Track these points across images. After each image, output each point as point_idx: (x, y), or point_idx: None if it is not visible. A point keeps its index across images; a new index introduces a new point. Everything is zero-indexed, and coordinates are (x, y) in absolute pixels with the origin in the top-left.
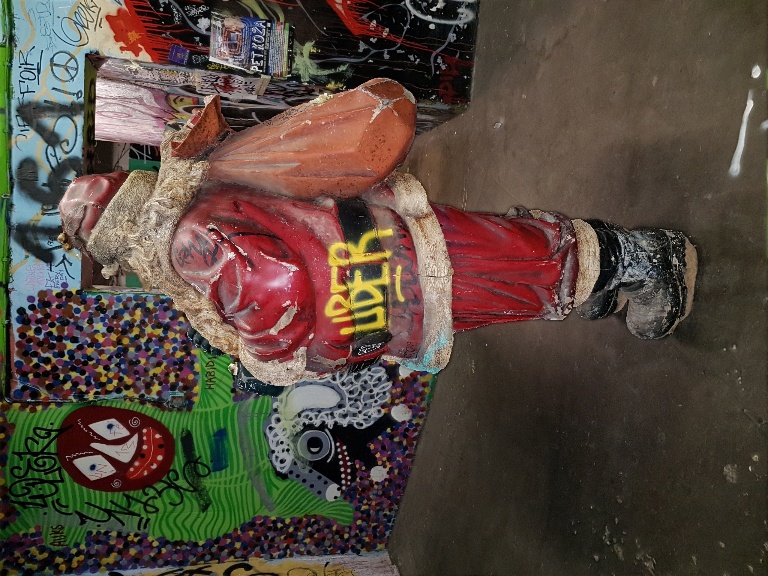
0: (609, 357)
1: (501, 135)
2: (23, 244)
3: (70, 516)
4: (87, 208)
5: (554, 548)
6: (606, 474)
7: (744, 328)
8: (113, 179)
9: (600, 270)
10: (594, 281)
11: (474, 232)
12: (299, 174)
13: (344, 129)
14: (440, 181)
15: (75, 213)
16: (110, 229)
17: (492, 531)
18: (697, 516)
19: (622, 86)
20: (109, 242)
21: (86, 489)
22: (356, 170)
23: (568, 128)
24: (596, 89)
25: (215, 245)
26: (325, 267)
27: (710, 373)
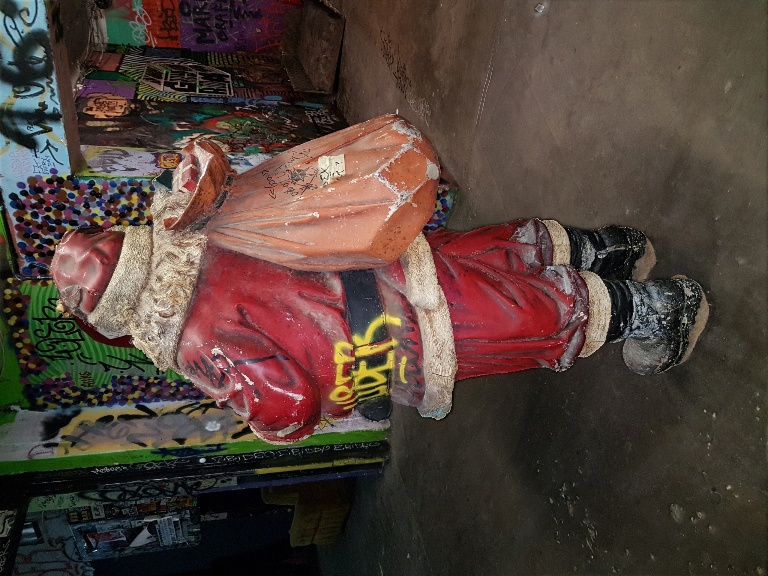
0: (601, 347)
1: (542, 25)
2: (0, 129)
3: (95, 365)
4: (83, 291)
5: (519, 471)
6: (574, 443)
7: (728, 405)
8: (105, 258)
9: (606, 336)
10: (597, 348)
11: (485, 311)
12: (305, 261)
13: (356, 224)
14: (465, 26)
15: (70, 292)
16: (110, 317)
17: (469, 425)
18: (639, 524)
19: (690, 65)
20: (111, 325)
21: (106, 345)
22: (367, 259)
23: (618, 73)
24: (661, 46)
25: (221, 373)
26: (331, 364)
27: (685, 422)
